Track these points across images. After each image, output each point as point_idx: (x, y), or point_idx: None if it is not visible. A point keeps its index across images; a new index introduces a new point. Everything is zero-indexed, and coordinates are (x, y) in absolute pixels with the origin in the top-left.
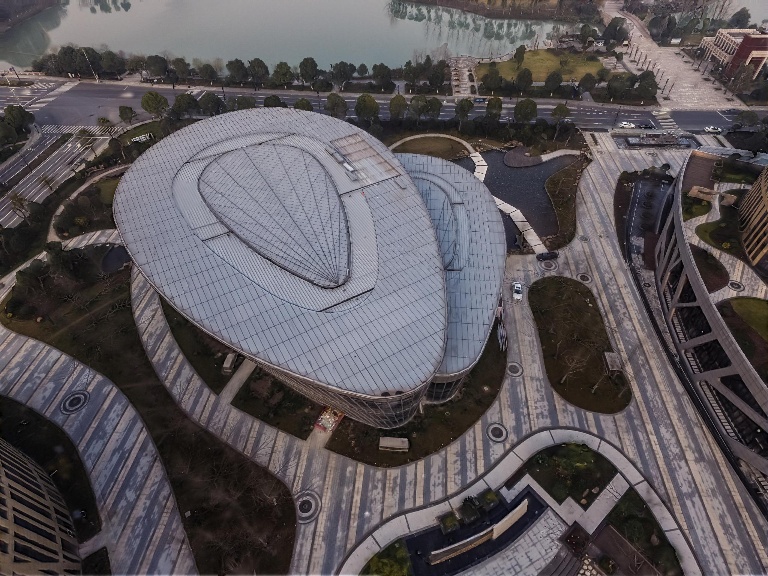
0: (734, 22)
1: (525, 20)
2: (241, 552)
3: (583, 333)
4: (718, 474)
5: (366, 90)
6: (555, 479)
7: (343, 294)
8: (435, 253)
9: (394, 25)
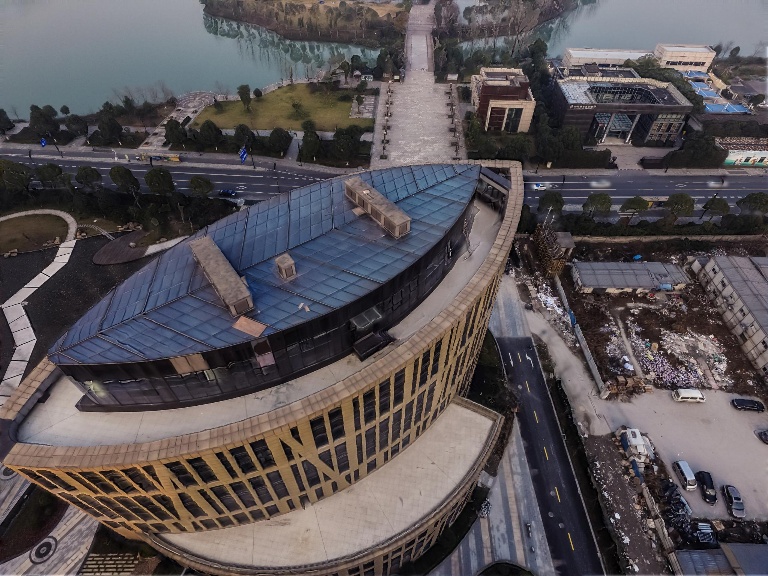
0: (527, 54)
1: (327, 42)
2: None
3: None
4: None
5: (36, 140)
6: None
7: None
8: None
9: (219, 40)
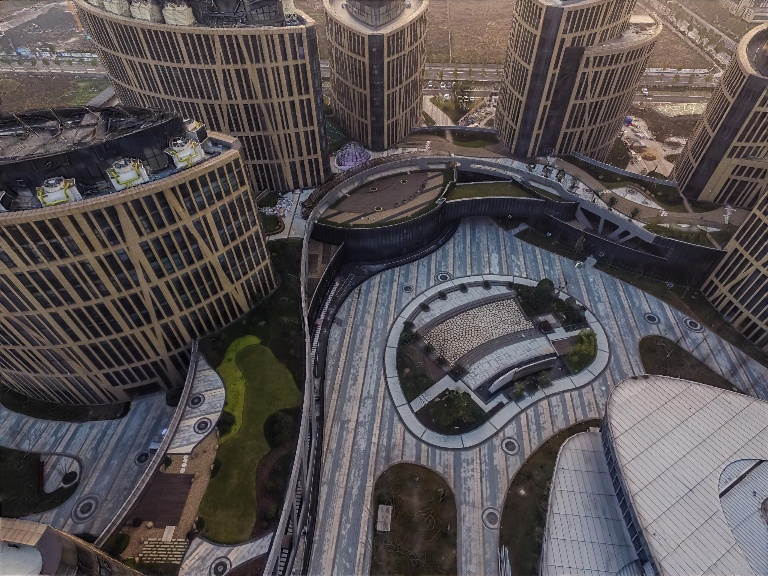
0: None
1: None
2: (679, 366)
3: (404, 569)
4: (338, 411)
5: None
6: (467, 406)
7: (752, 486)
8: (666, 567)
9: None
